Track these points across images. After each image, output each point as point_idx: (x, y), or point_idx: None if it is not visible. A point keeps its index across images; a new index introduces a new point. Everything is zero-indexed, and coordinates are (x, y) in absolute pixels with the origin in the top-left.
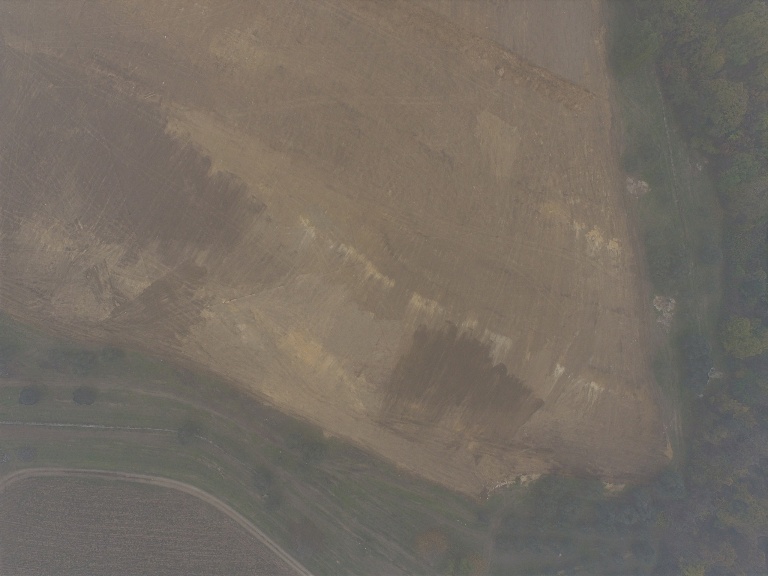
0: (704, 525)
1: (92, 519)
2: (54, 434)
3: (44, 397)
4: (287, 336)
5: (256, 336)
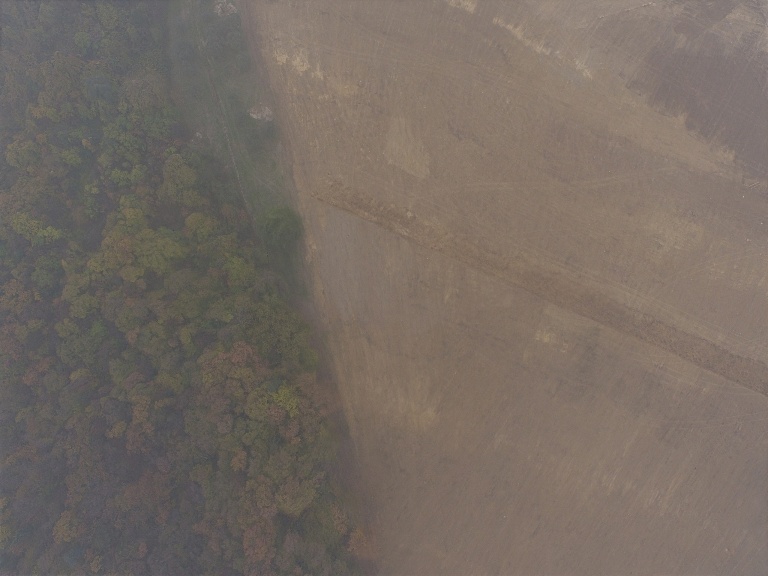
0: None
1: None
2: None
3: None
4: None
5: None
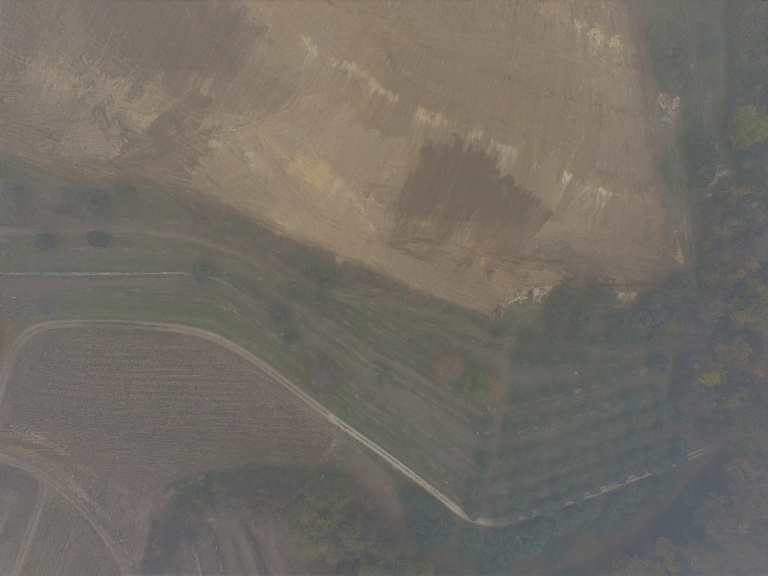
0: (718, 328)
1: (113, 368)
2: (71, 284)
3: (59, 245)
4: (295, 161)
5: (264, 163)
